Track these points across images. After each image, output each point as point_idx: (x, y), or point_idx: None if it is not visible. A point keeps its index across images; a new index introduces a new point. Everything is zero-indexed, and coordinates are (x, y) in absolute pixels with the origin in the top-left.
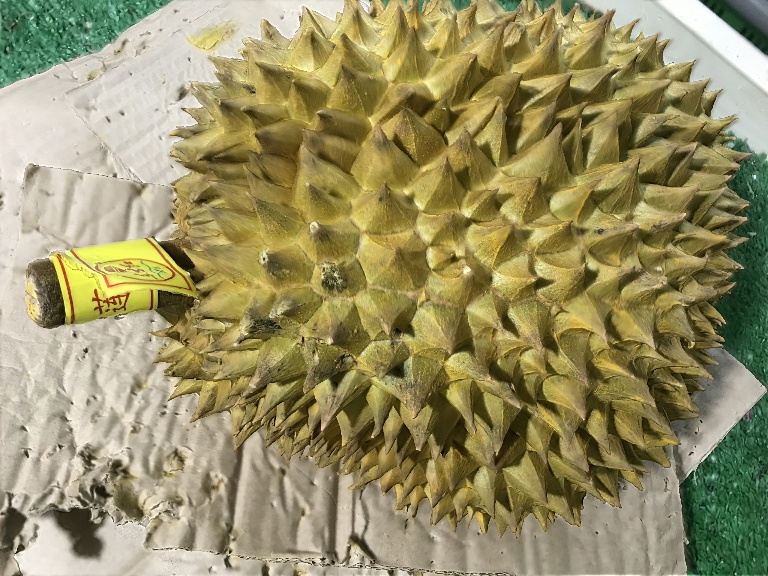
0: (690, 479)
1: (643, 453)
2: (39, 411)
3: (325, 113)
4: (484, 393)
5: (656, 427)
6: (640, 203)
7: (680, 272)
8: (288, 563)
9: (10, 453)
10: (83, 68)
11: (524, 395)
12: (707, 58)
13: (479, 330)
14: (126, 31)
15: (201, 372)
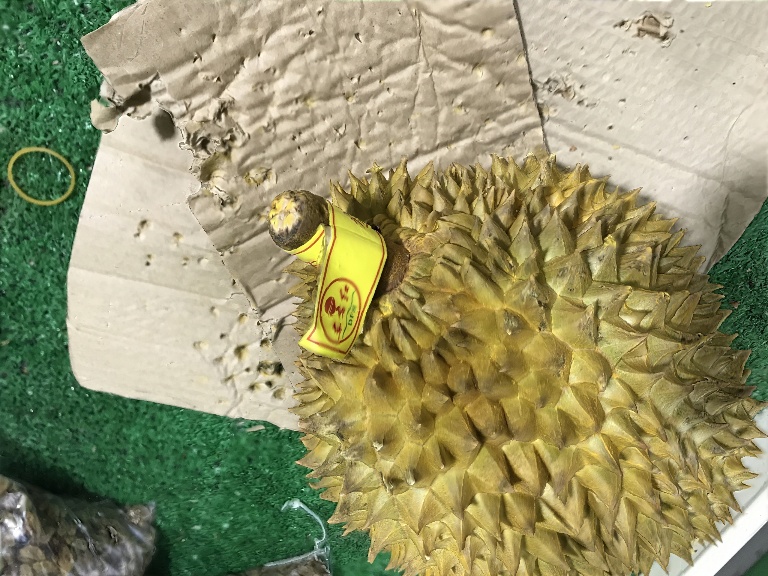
0: None
1: None
2: (236, 37)
3: None
4: None
5: None
6: None
7: None
8: None
9: (188, 47)
10: None
11: None
12: None
13: None
14: None
15: None
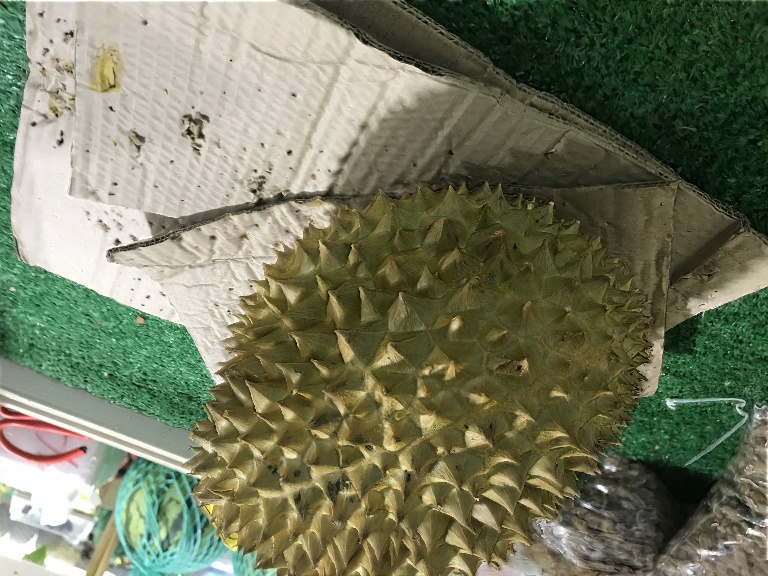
0: (700, 313)
1: None
2: None
3: None
4: None
5: None
6: (454, 557)
7: None
8: None
9: None
10: (40, 105)
11: None
12: None
13: None
14: (28, 53)
15: None
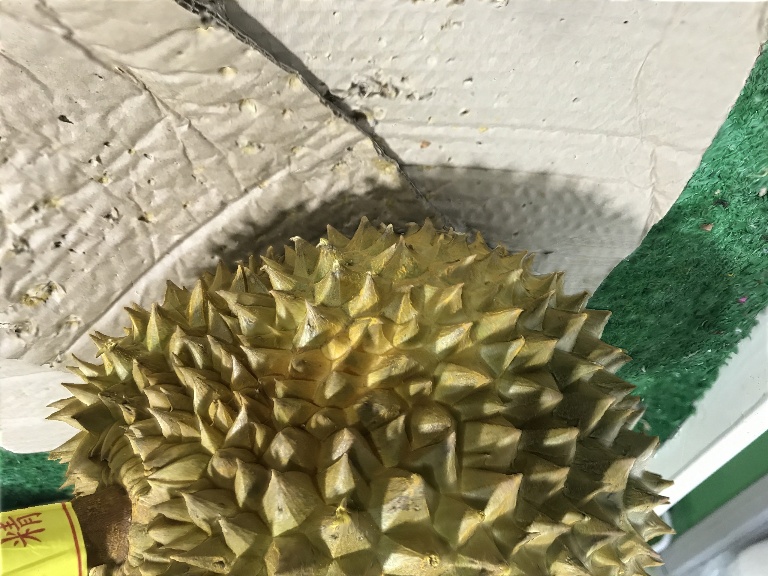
0: None
1: None
2: None
3: None
4: None
5: None
6: None
7: None
8: None
9: None
10: None
11: None
12: None
13: None
14: None
15: None
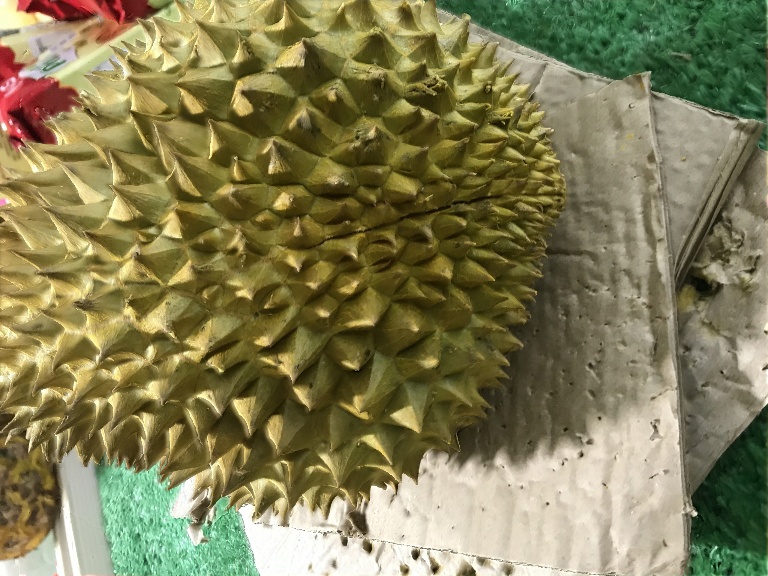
0: None
1: (389, 421)
2: None
3: None
4: None
5: None
6: (101, 226)
7: (136, 273)
8: None
9: None
10: None
11: None
12: None
13: None
14: None
15: None
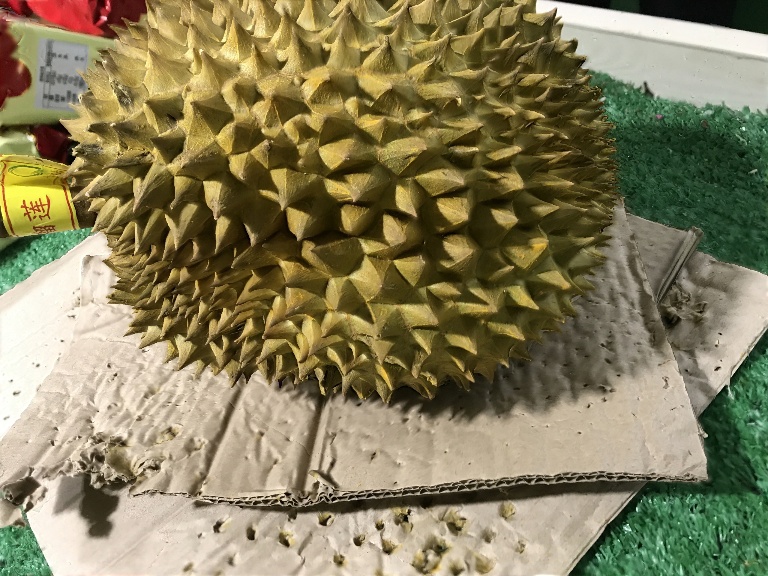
0: (725, 396)
1: (535, 279)
2: (70, 417)
3: (138, 26)
4: (271, 171)
5: (503, 221)
6: None
7: (431, 51)
8: (274, 526)
9: (40, 443)
10: None
11: (297, 158)
12: (645, 48)
13: (235, 105)
14: None
15: (128, 284)
